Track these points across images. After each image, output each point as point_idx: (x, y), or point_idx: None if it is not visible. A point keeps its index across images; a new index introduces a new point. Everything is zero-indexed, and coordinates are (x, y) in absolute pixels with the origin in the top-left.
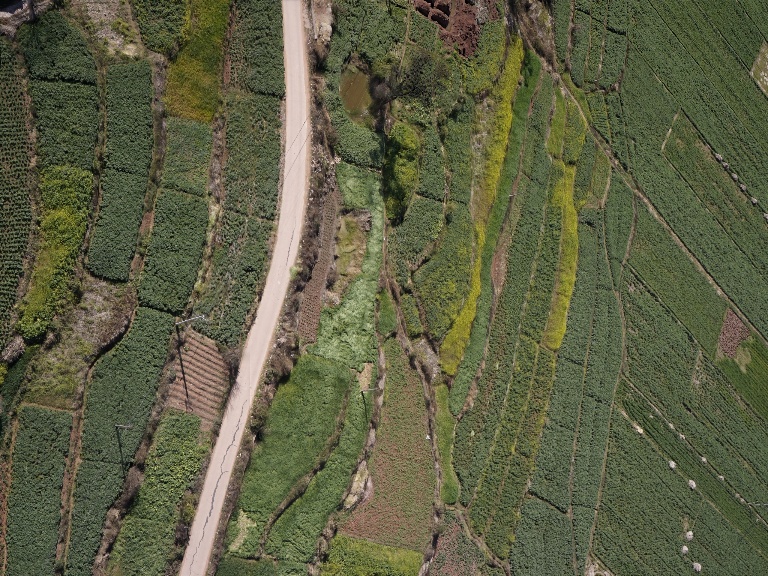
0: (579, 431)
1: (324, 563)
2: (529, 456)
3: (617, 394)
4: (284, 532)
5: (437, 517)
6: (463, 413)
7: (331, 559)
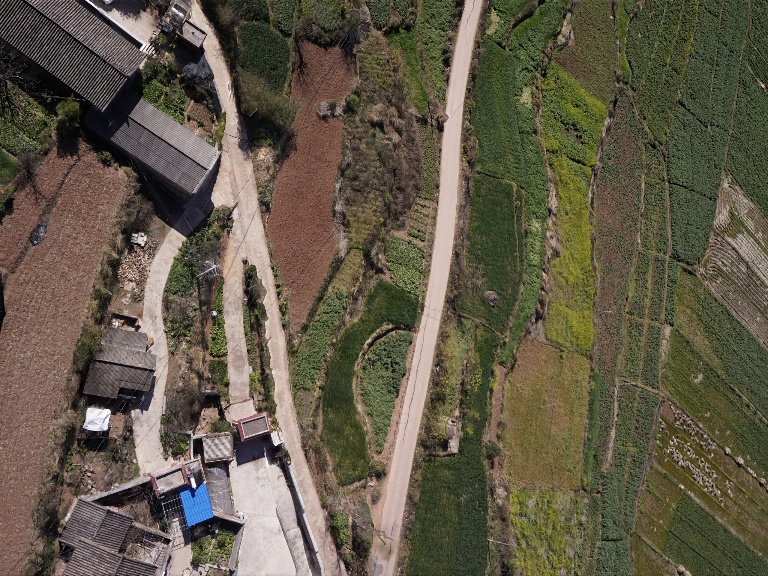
0: (716, 70)
1: (544, 78)
2: (679, 73)
3: (744, 52)
4: (520, 38)
5: (617, 84)
6: (634, 14)
7: (548, 77)
